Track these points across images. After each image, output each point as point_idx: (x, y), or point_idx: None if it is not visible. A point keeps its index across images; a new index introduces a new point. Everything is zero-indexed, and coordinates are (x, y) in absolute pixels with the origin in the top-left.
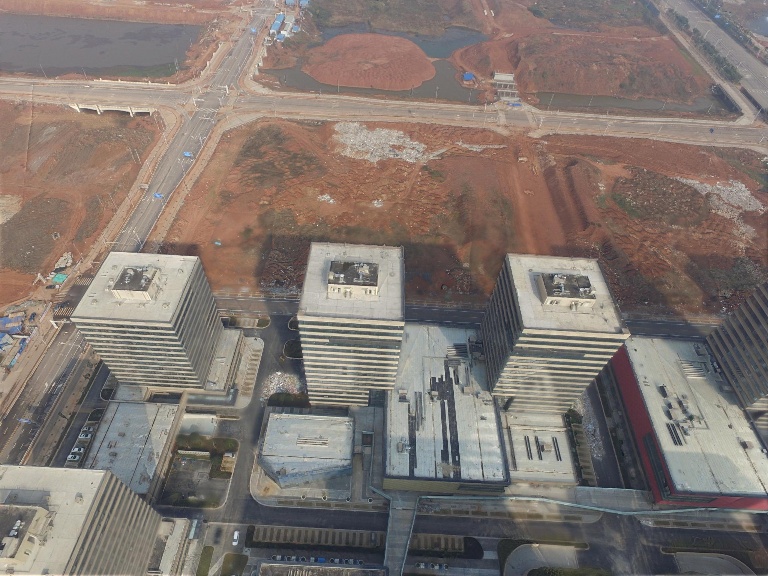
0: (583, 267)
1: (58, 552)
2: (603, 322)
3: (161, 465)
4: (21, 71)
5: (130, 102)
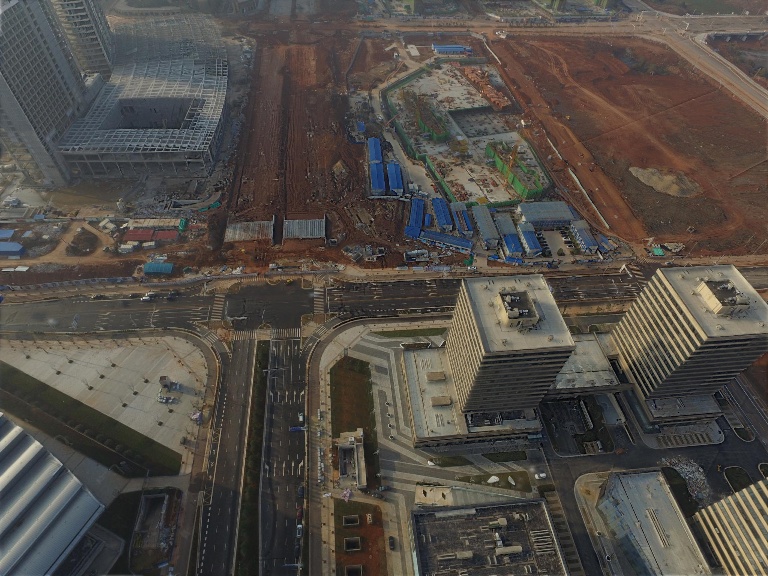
0: None
1: (518, 342)
2: None
3: (568, 391)
4: None
5: None
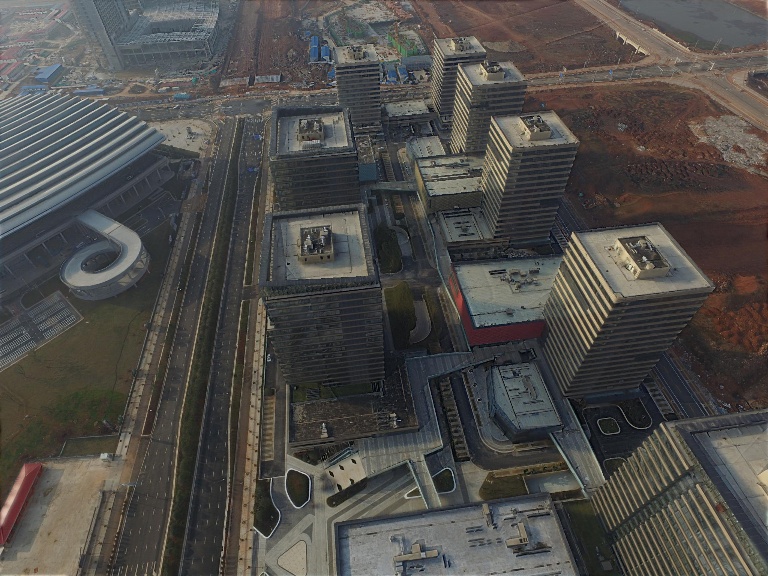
0: (567, 139)
1: None
2: (518, 143)
3: (402, 118)
4: (634, 12)
5: (646, 45)
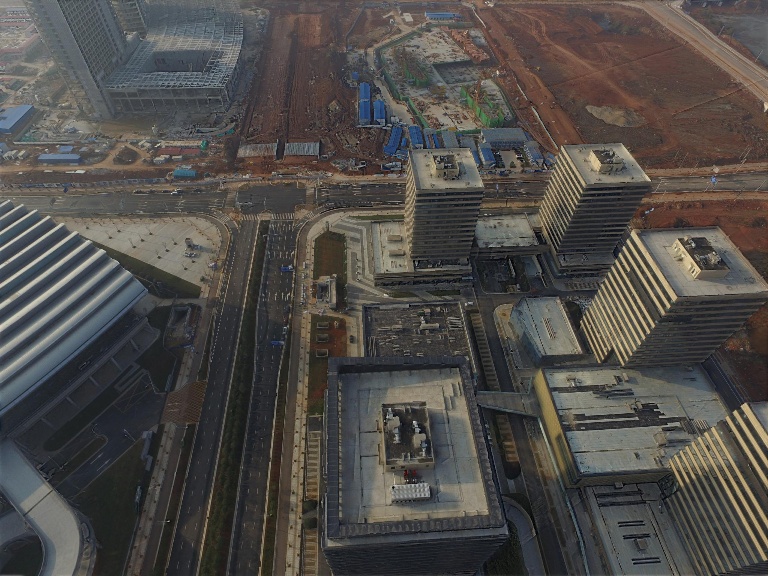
0: None
1: (442, 186)
2: None
3: (497, 250)
4: None
5: None
